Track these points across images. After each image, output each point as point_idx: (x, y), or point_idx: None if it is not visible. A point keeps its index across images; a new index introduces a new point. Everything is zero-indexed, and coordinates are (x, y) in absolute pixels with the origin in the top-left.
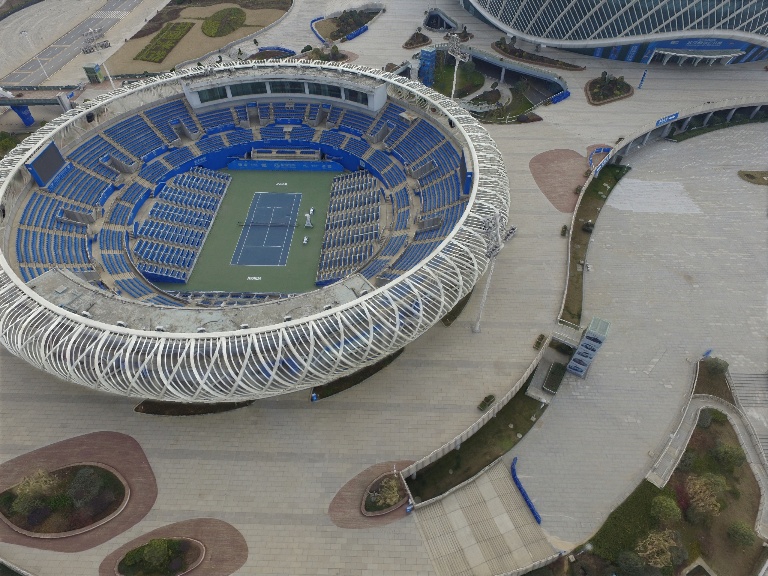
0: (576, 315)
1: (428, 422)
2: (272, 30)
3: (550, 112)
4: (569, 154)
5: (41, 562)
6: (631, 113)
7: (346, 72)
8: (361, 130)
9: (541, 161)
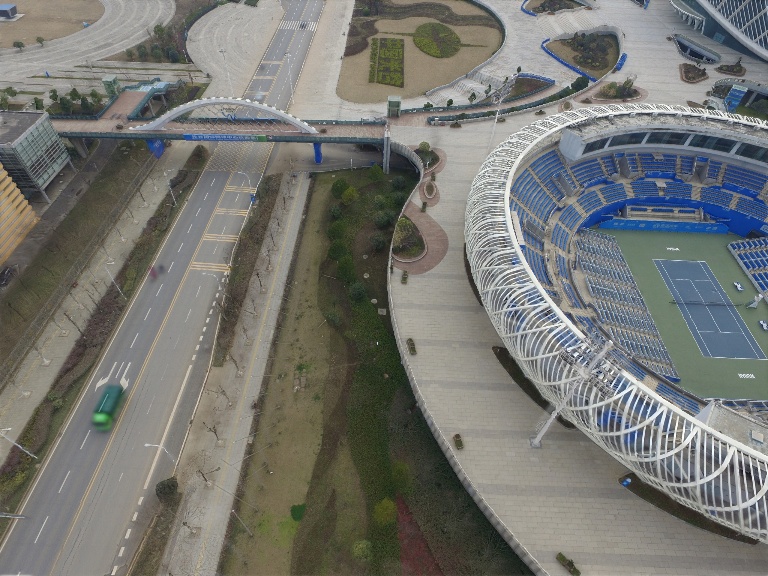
0: None
1: None
2: (505, 52)
3: None
4: None
5: None
6: None
7: (736, 123)
8: (757, 190)
9: None
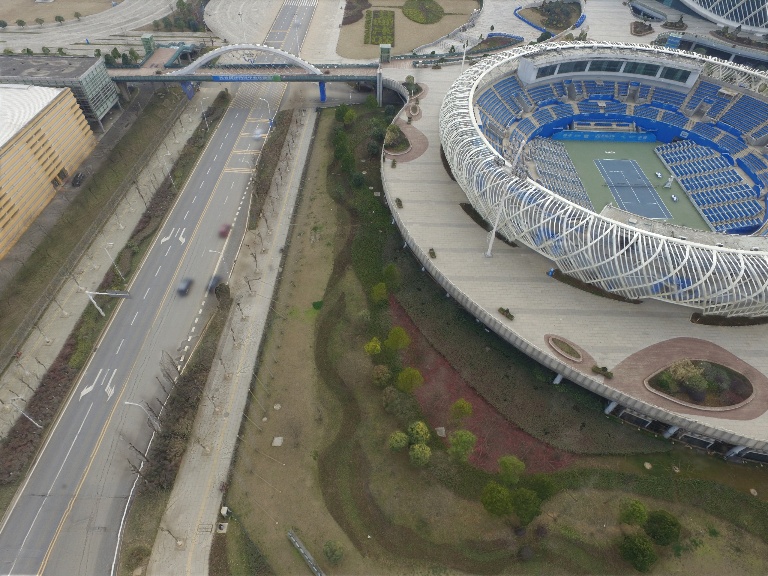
0: None
1: None
2: (482, 18)
3: None
4: None
5: (727, 427)
6: None
7: (660, 53)
8: (678, 105)
9: None
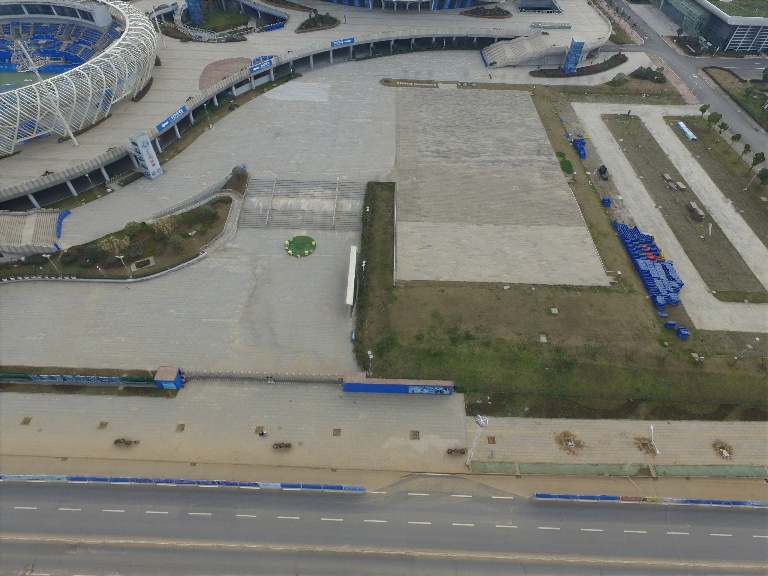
0: (178, 151)
1: (3, 183)
2: None
3: (258, 36)
4: (243, 60)
5: None
6: (320, 38)
7: None
8: (91, 41)
9: (218, 64)
